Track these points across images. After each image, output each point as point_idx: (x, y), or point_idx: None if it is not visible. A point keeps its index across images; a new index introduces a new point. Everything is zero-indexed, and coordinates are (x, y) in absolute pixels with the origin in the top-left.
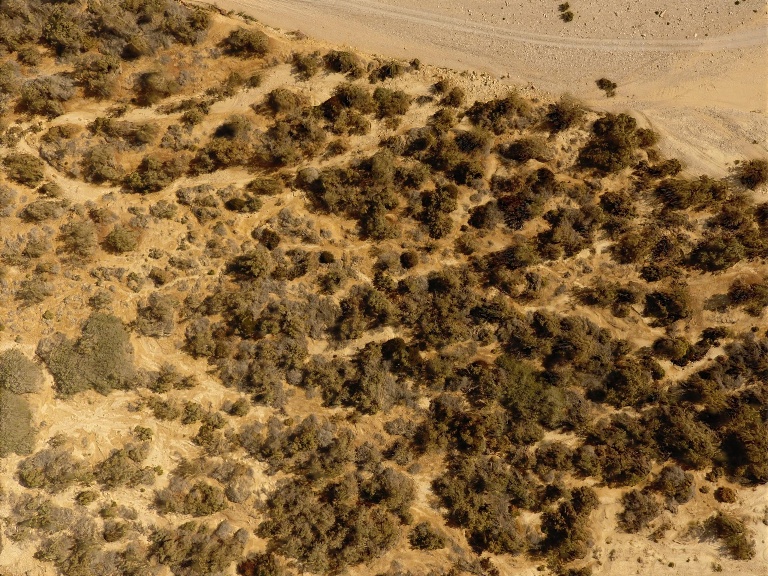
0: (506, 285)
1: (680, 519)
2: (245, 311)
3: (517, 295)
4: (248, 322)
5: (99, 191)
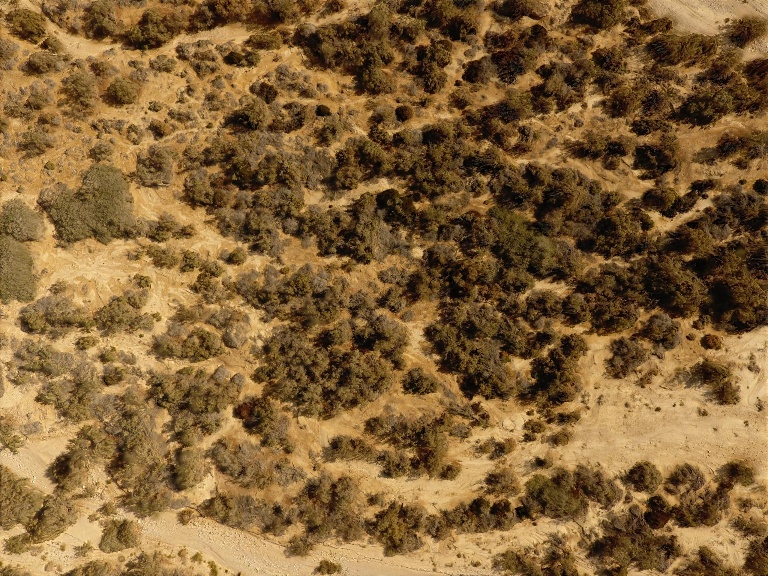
0: (499, 136)
1: (667, 365)
2: (243, 160)
3: (510, 148)
4: (245, 171)
5: (100, 47)
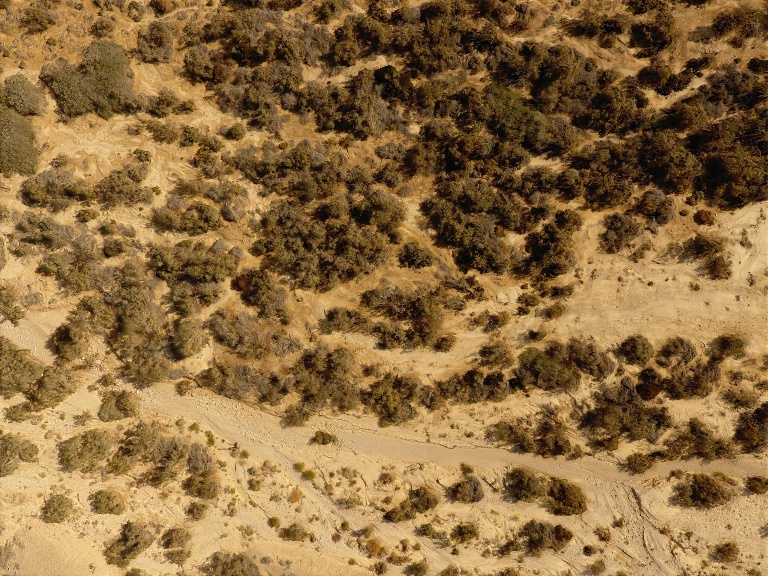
0: (496, 12)
1: (660, 240)
2: (242, 35)
3: (507, 26)
4: (245, 45)
5: None
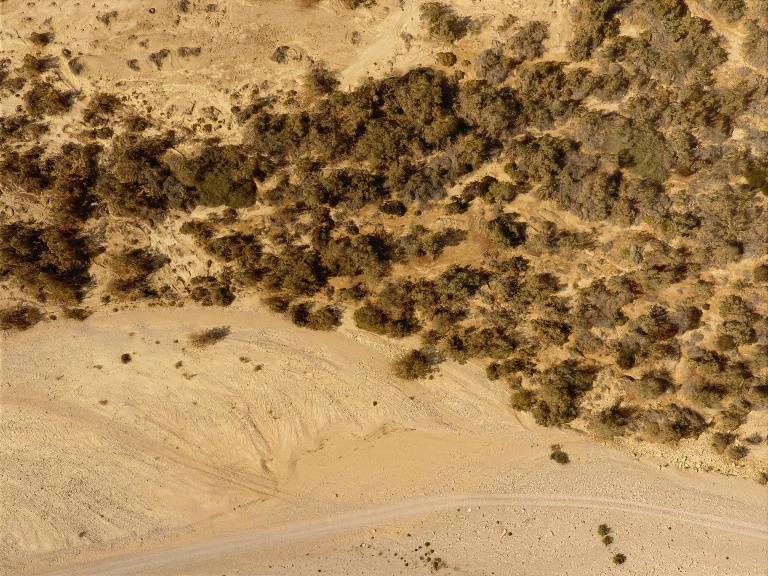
0: None
1: (489, 36)
2: None
3: (651, 241)
4: None
5: None
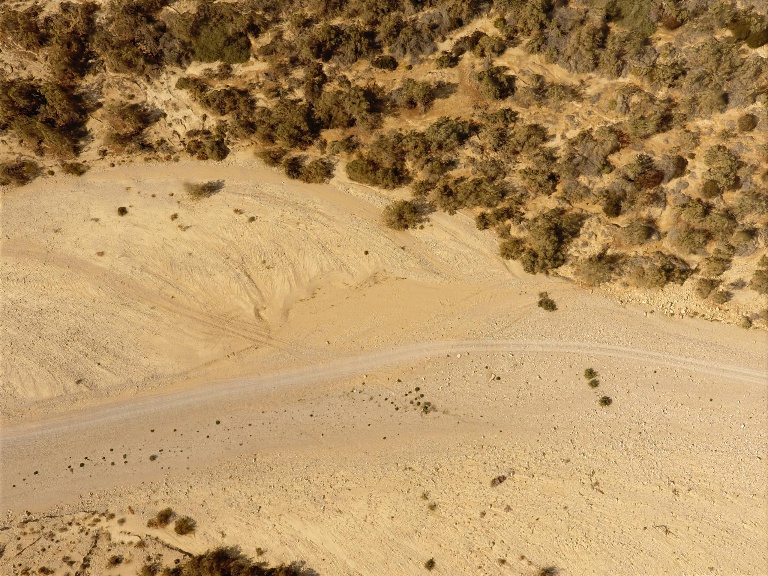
0: None
1: None
2: None
3: (638, 92)
4: None
5: None
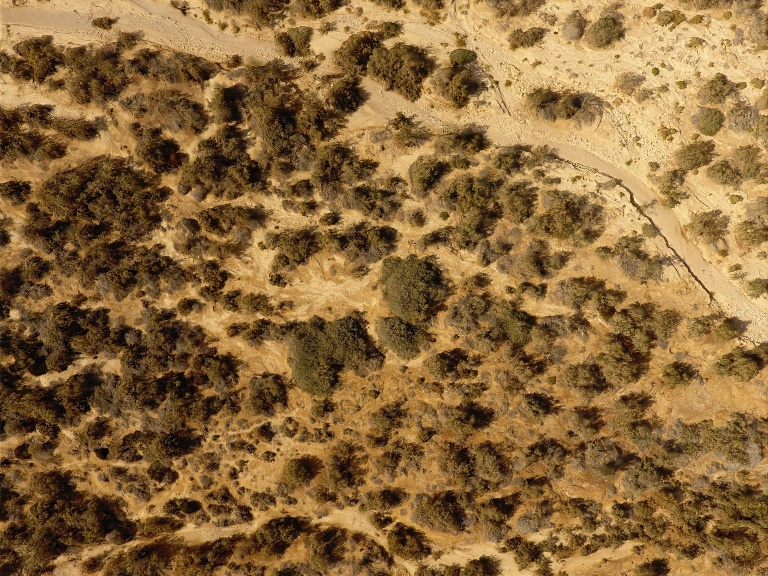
0: None
1: None
2: None
3: None
4: None
5: (333, 519)
